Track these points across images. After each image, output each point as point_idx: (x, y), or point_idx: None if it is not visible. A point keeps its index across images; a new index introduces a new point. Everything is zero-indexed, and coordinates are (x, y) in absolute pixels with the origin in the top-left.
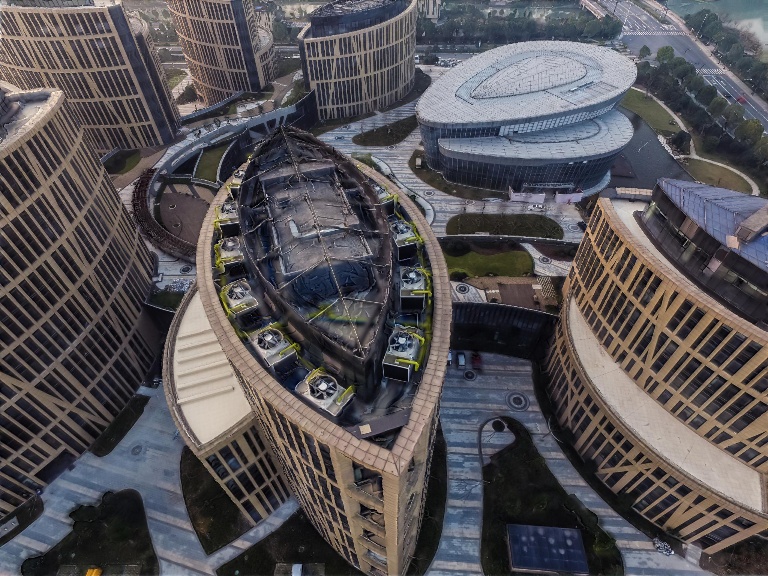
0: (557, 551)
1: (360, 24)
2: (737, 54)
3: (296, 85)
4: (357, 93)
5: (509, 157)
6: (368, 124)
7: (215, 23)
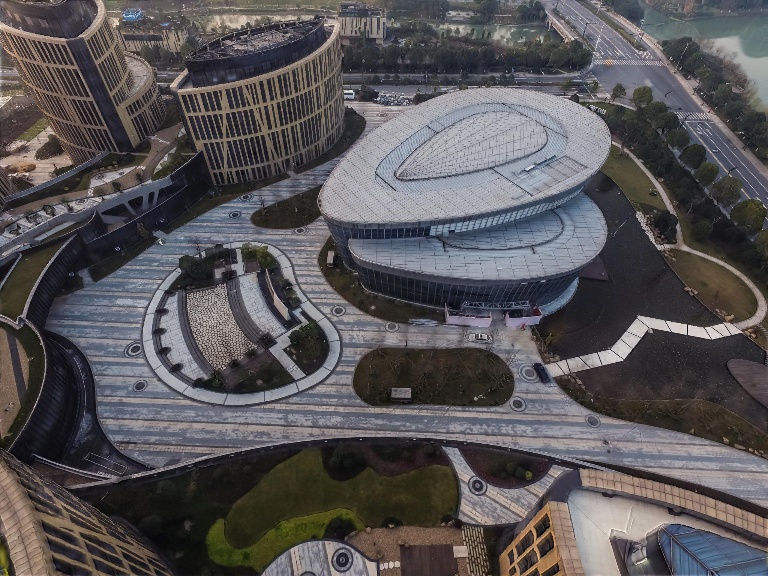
0: None
1: (256, 68)
2: (724, 96)
3: (178, 144)
4: (261, 153)
5: (440, 275)
6: (276, 192)
7: (52, 68)
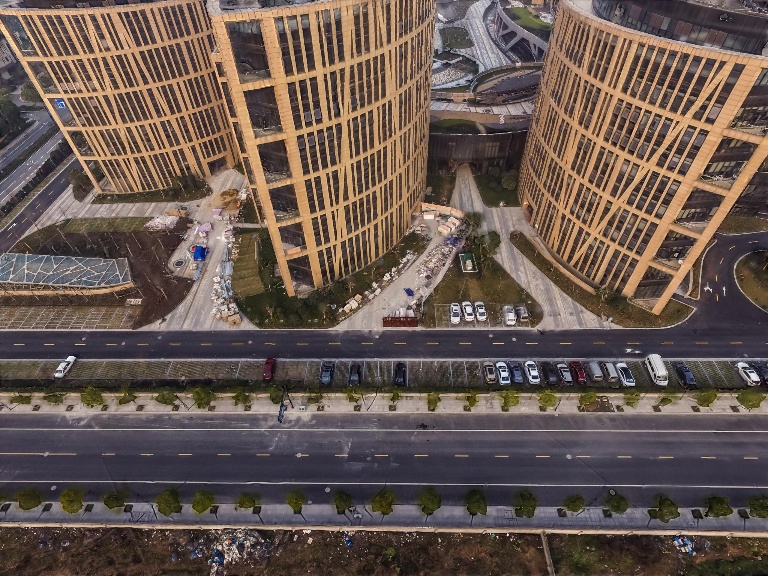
0: None
1: None
2: None
3: None
4: None
5: None
6: None
7: None
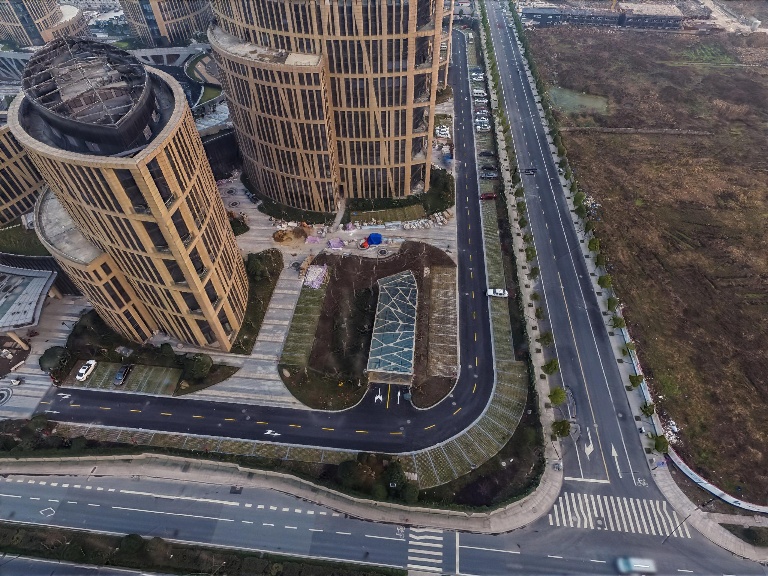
0: None
1: None
2: None
3: None
4: None
5: None
6: None
7: None
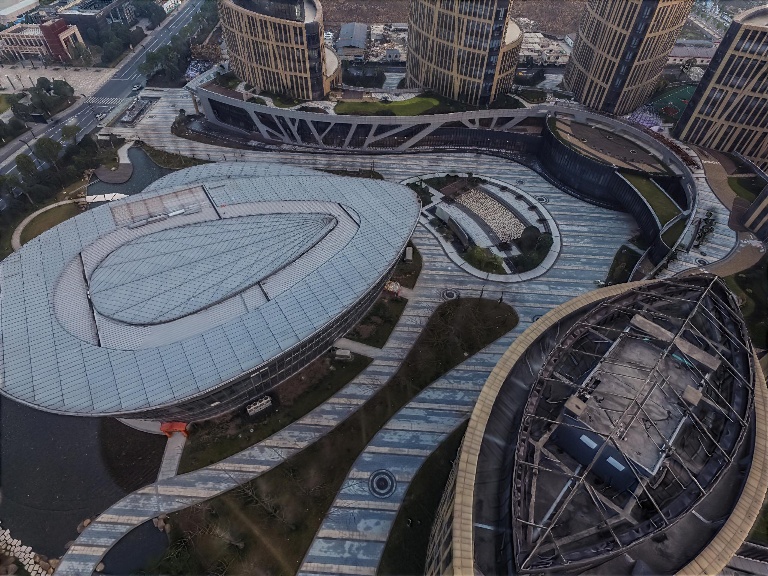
0: (360, 72)
1: None
2: None
3: None
4: None
5: None
6: None
7: None
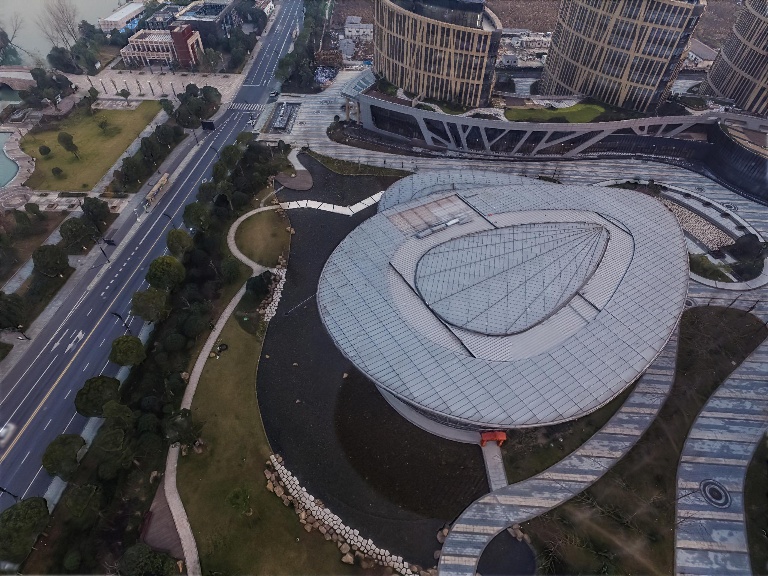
0: None
1: None
2: None
3: None
4: None
5: None
6: None
7: None
